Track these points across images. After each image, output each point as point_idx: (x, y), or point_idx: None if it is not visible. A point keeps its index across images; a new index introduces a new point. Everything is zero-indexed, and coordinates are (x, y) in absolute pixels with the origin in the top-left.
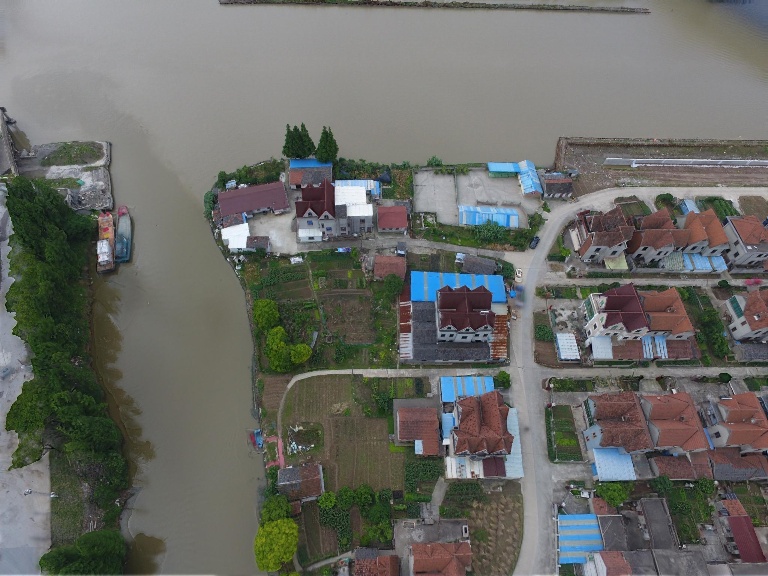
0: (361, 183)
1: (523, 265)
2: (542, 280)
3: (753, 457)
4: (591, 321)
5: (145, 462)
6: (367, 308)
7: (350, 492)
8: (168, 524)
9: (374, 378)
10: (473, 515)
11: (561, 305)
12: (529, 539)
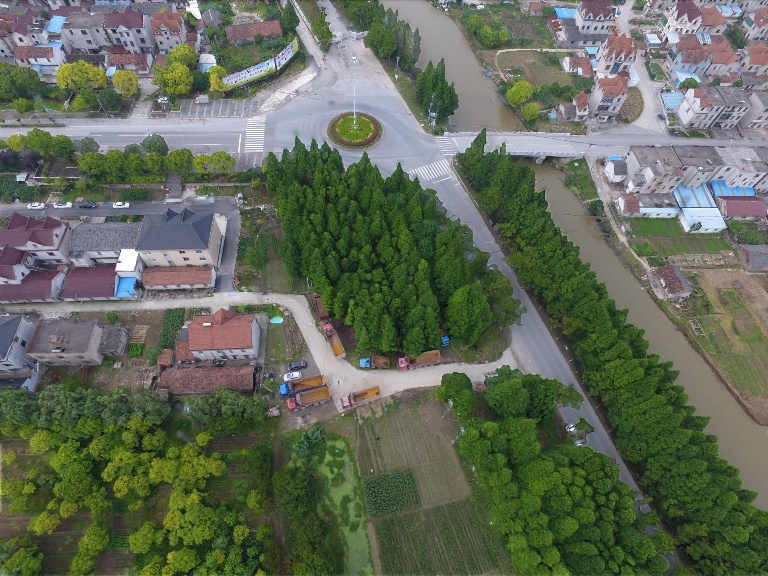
0: None
1: None
2: (631, 18)
3: (763, 75)
4: (666, 26)
5: None
6: (530, 27)
7: (548, 86)
8: None
9: (545, 51)
10: None
11: (644, 27)
12: (647, 103)
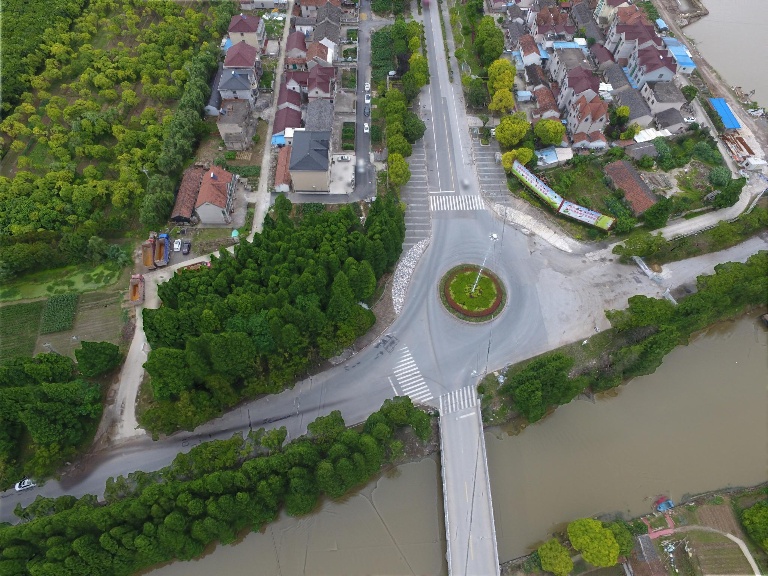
0: None
1: None
2: None
3: None
4: None
5: (595, 394)
6: None
7: None
8: (551, 423)
9: None
10: None
11: None
12: None
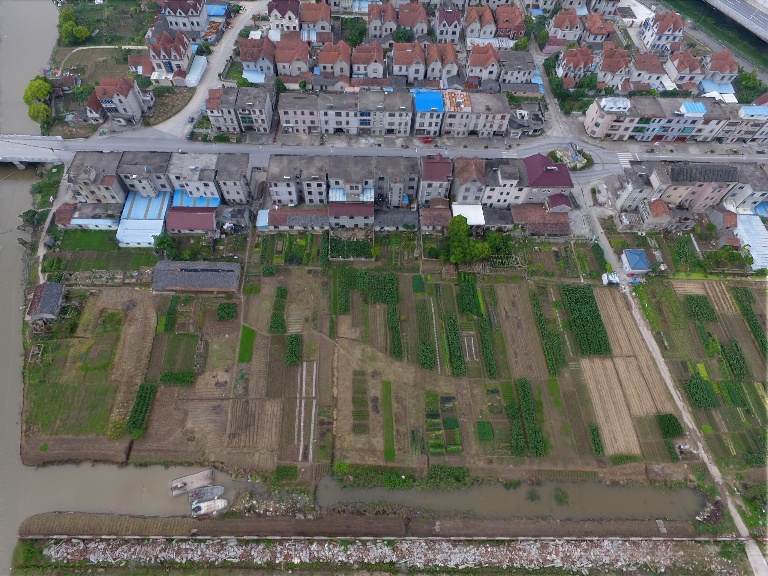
0: None
1: (249, 7)
2: None
3: (339, 75)
4: None
5: None
6: None
7: (92, 86)
8: None
9: (127, 49)
10: (163, 98)
11: (265, 24)
12: (190, 105)
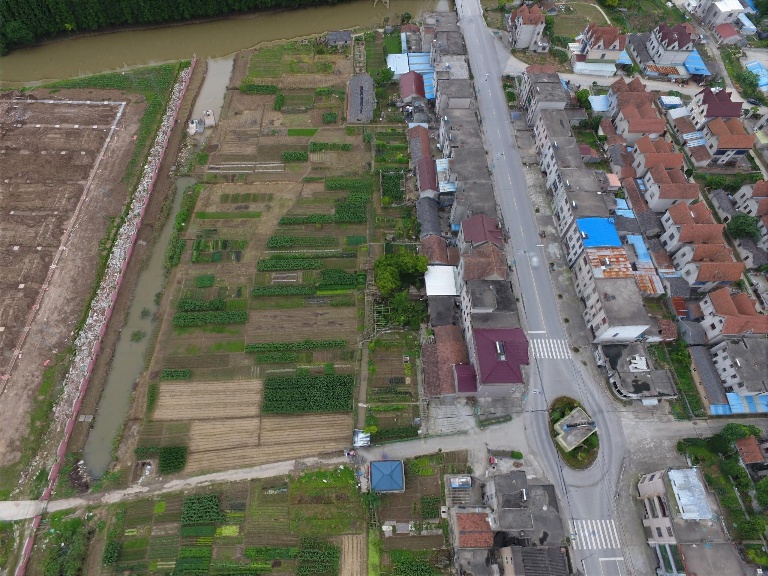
0: (749, 23)
1: None
2: None
3: None
4: None
5: None
6: None
7: None
8: None
9: None
10: None
11: None
12: None
